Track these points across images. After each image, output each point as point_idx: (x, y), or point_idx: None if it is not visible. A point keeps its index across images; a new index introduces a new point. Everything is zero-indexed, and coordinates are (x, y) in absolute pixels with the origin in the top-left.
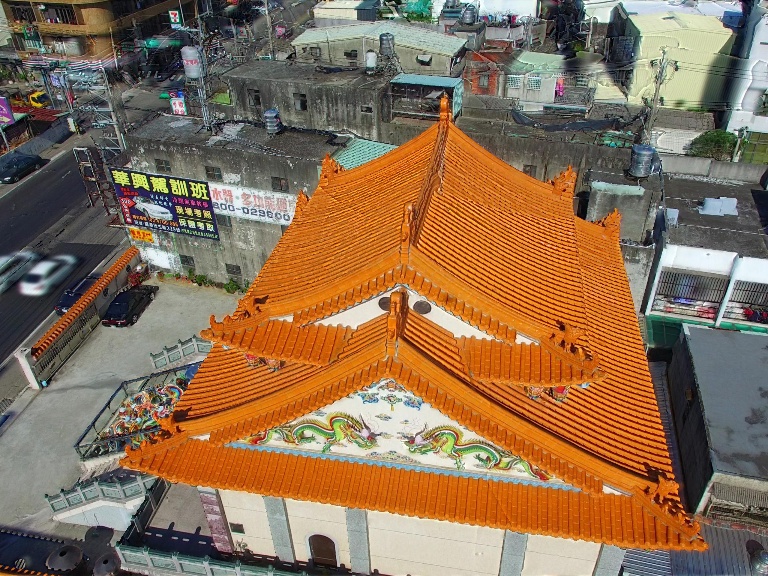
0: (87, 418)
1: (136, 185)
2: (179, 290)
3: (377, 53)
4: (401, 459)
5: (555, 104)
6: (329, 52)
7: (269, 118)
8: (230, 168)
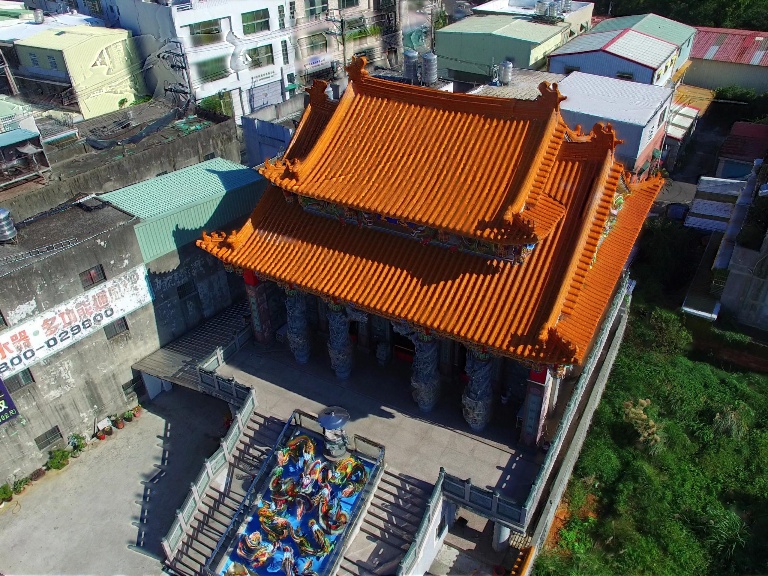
0: None
1: None
2: None
3: None
4: None
5: (45, 139)
6: None
7: (4, 220)
8: (16, 300)
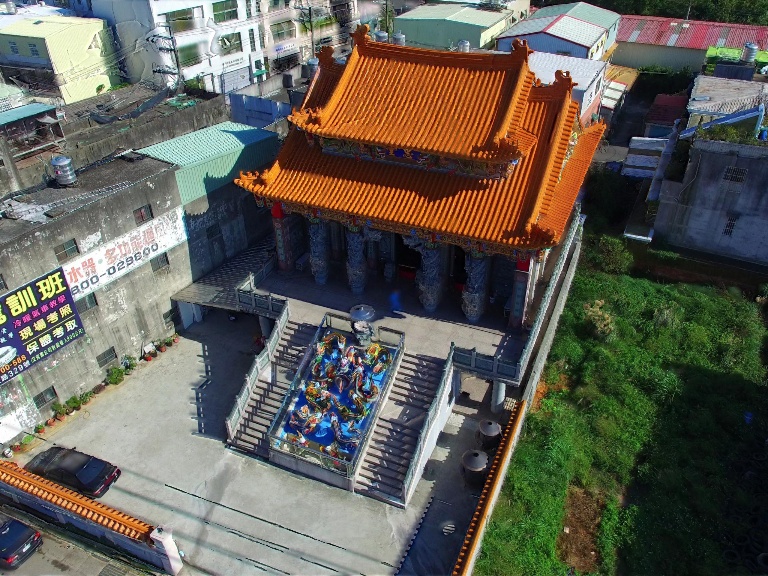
0: (269, 501)
1: None
2: (71, 430)
3: None
4: None
5: None
6: None
7: (68, 166)
8: (87, 230)
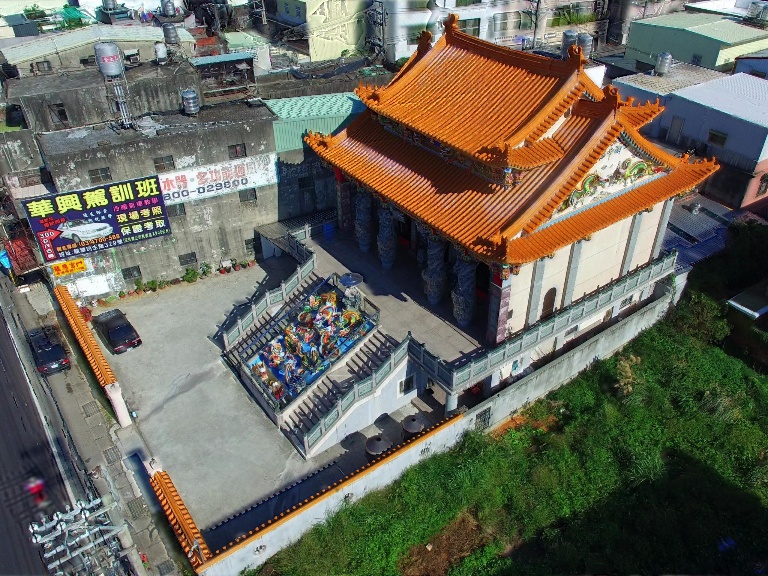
0: (218, 407)
1: (63, 210)
2: (140, 303)
3: (165, 43)
4: (604, 196)
5: (274, 70)
6: (61, 63)
7: (192, 99)
8: (183, 152)
